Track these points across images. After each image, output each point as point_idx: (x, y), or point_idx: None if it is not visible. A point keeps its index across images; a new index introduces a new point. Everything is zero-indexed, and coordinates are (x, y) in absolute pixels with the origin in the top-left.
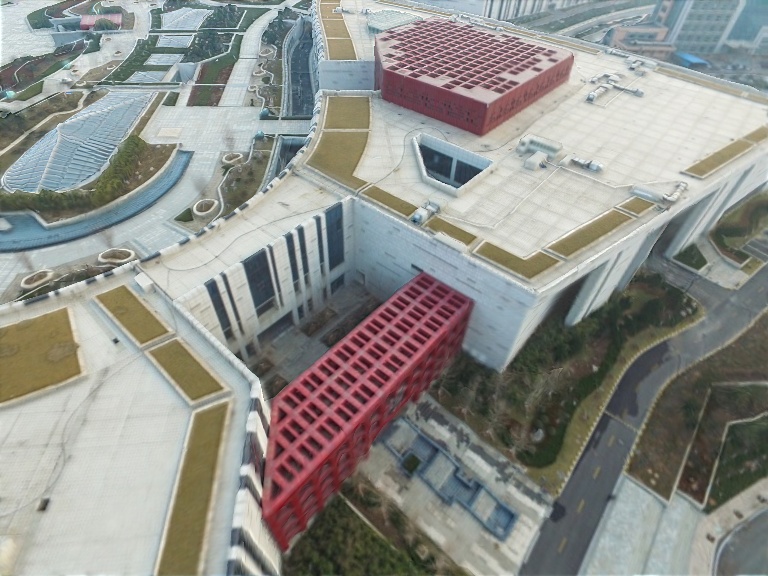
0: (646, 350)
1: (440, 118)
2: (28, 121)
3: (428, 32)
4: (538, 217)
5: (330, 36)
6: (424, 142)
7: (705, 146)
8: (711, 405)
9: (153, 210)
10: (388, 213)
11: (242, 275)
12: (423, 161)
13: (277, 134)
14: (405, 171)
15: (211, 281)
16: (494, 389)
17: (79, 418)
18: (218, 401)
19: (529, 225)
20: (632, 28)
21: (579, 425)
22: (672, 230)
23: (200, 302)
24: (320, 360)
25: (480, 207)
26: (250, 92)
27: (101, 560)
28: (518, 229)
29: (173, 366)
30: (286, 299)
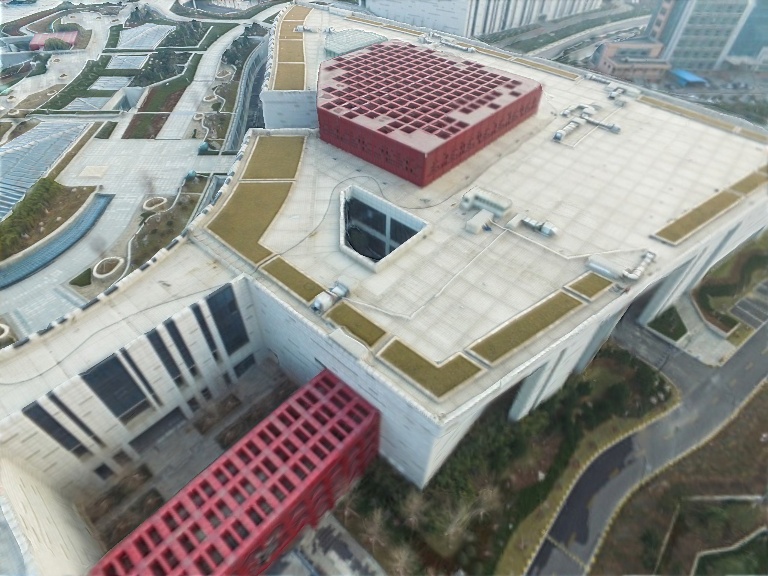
0: (606, 449)
1: (379, 164)
2: None
3: (382, 59)
4: (468, 302)
5: (282, 60)
6: (355, 195)
7: (683, 199)
8: (679, 528)
9: (48, 271)
10: (287, 296)
11: (83, 389)
12: (345, 223)
13: (212, 173)
14: (322, 236)
15: (32, 405)
16: (409, 514)
17: None
18: None
19: (454, 313)
20: (623, 44)
21: (513, 557)
22: (645, 296)
23: (17, 432)
24: (167, 505)
25: (400, 287)
26: (195, 121)
27: None
28: (440, 319)
29: None
30: (166, 398)
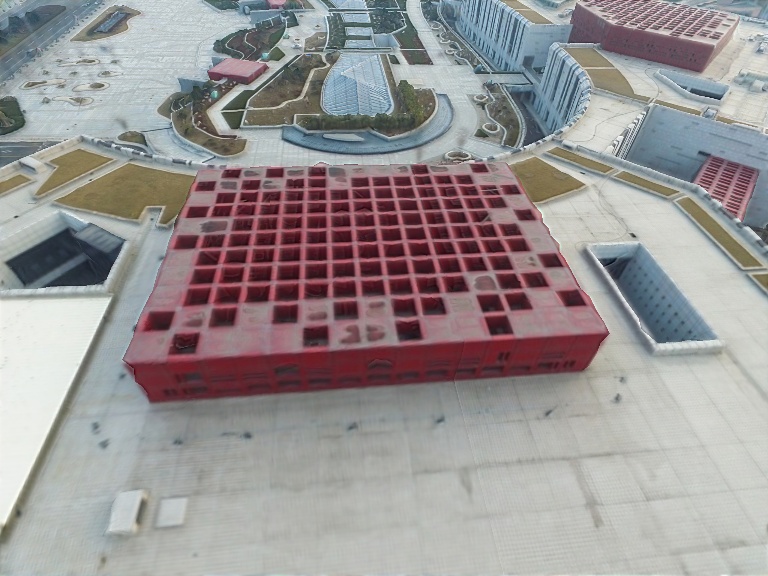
0: None
1: (662, 61)
2: (301, 73)
3: (615, 1)
4: None
5: (515, 8)
6: None
7: None
8: None
9: (454, 130)
10: None
11: (619, 145)
12: None
13: (499, 83)
14: (667, 92)
15: (614, 144)
16: (766, 236)
17: (606, 204)
18: (684, 196)
19: None
20: (730, 7)
21: None
22: None
23: None
24: None
25: (741, 112)
26: (449, 55)
27: (692, 254)
28: None
29: (638, 182)
30: None
